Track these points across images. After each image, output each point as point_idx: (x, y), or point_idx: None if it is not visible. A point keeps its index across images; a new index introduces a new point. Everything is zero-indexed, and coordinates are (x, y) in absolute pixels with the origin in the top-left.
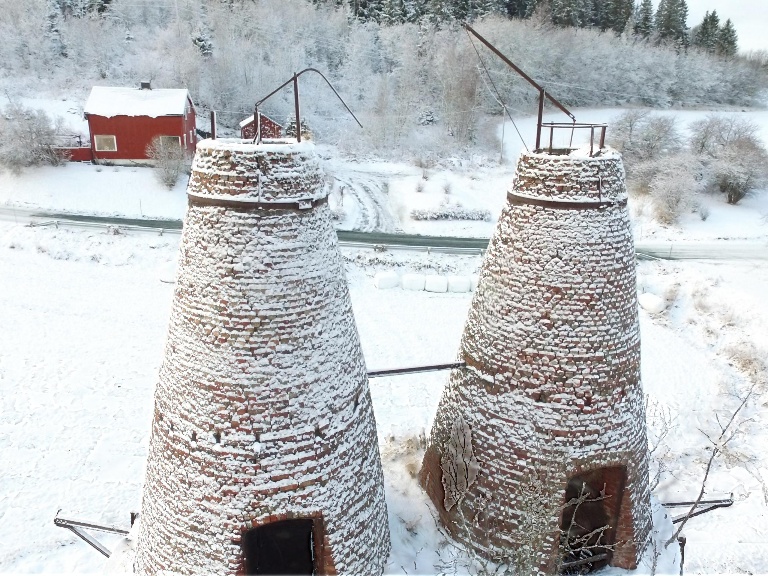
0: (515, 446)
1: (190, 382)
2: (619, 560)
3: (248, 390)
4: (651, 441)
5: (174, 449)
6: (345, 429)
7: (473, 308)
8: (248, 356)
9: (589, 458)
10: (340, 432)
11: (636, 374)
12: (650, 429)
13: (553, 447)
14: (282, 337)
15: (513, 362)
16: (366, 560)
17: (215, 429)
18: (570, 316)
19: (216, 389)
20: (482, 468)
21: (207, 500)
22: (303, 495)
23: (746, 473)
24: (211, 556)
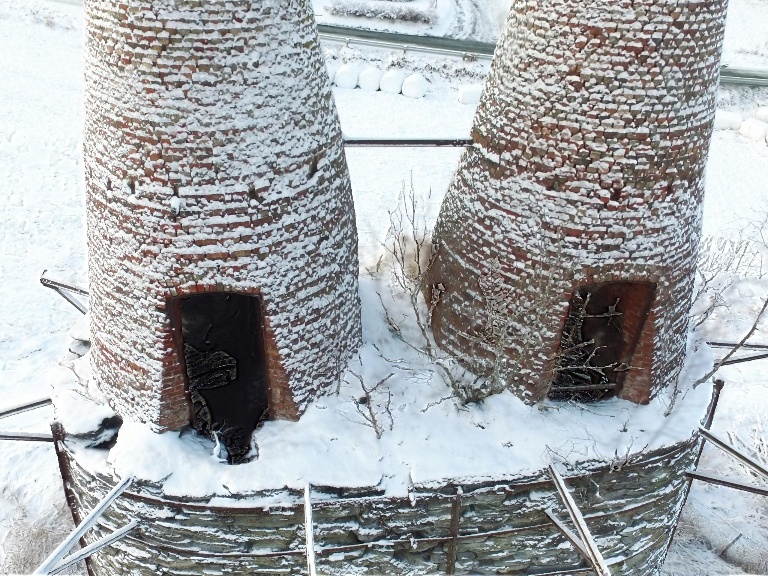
0: (514, 244)
1: (100, 117)
2: (629, 392)
3: (160, 129)
4: (738, 291)
5: (94, 199)
6: (293, 197)
7: (490, 67)
8: (157, 84)
9: (606, 267)
10: (286, 199)
11: (694, 167)
12: (740, 279)
13: (560, 249)
14: (200, 62)
15: (525, 136)
16: (321, 351)
17: (128, 177)
18: (608, 71)
19: (125, 126)
20: (474, 268)
21: (129, 260)
22: (235, 266)
23: None
24: (138, 321)
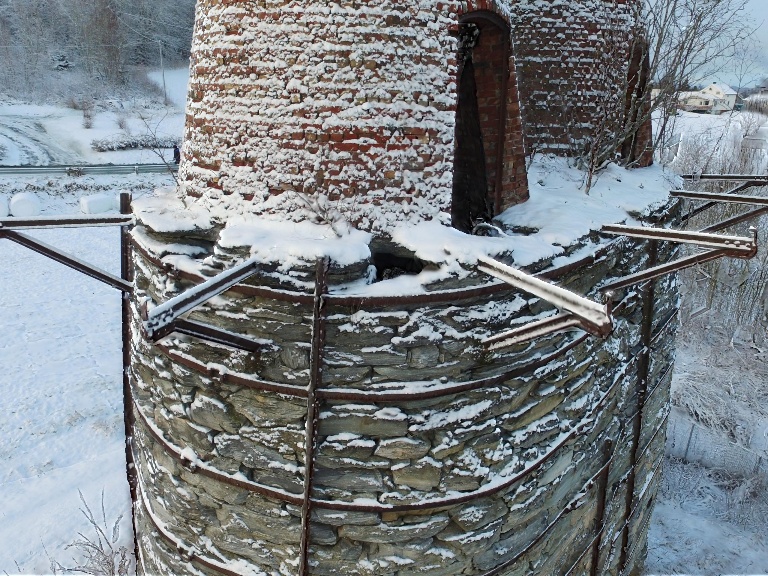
0: (585, 20)
1: None
2: (640, 160)
3: None
4: None
5: None
6: None
7: None
8: None
9: None
10: None
11: None
12: None
13: (617, 15)
14: None
15: None
16: None
17: None
18: None
19: None
20: (552, 58)
21: None
22: None
23: None
24: (422, 59)
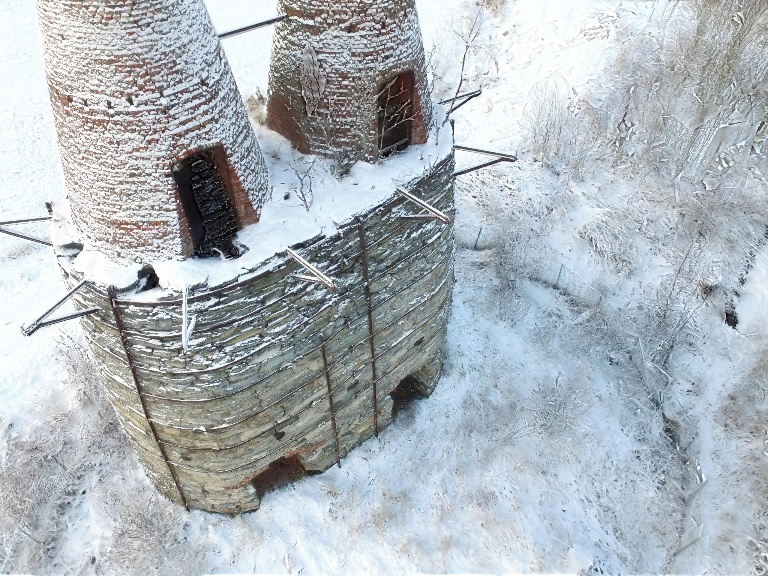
0: (339, 71)
1: (91, 61)
2: (416, 140)
3: (143, 57)
4: None
5: (94, 120)
6: (219, 79)
7: None
8: (135, 28)
9: (390, 68)
10: (217, 81)
11: None
12: None
13: (365, 65)
14: (156, 7)
15: (326, 4)
16: (256, 174)
17: (126, 95)
18: None
19: (116, 61)
20: None
21: (136, 151)
22: (206, 132)
23: (492, 92)
24: (152, 191)
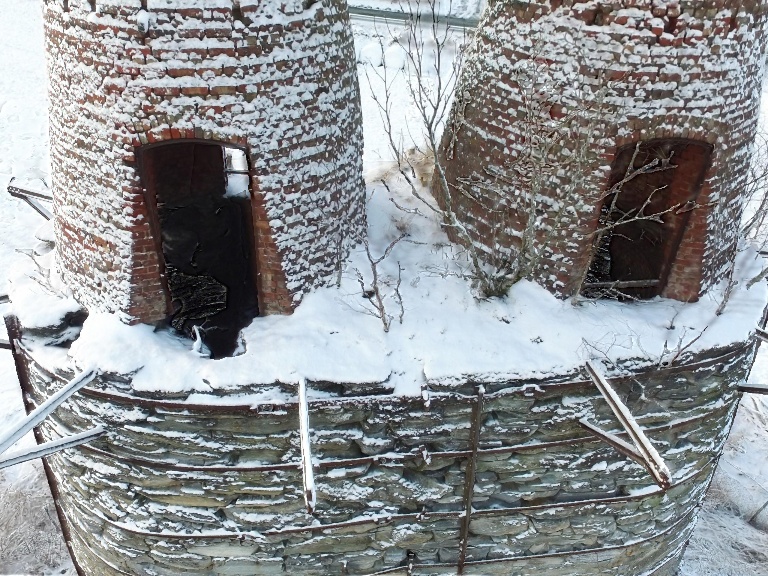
0: None
1: None
2: (675, 289)
3: None
4: None
5: (50, 31)
6: (286, 26)
7: None
8: None
9: (656, 119)
10: (277, 27)
11: None
12: None
13: None
14: None
15: None
16: (319, 230)
17: None
18: None
19: None
20: (497, 137)
21: (90, 101)
22: (217, 107)
23: None
24: (102, 181)
